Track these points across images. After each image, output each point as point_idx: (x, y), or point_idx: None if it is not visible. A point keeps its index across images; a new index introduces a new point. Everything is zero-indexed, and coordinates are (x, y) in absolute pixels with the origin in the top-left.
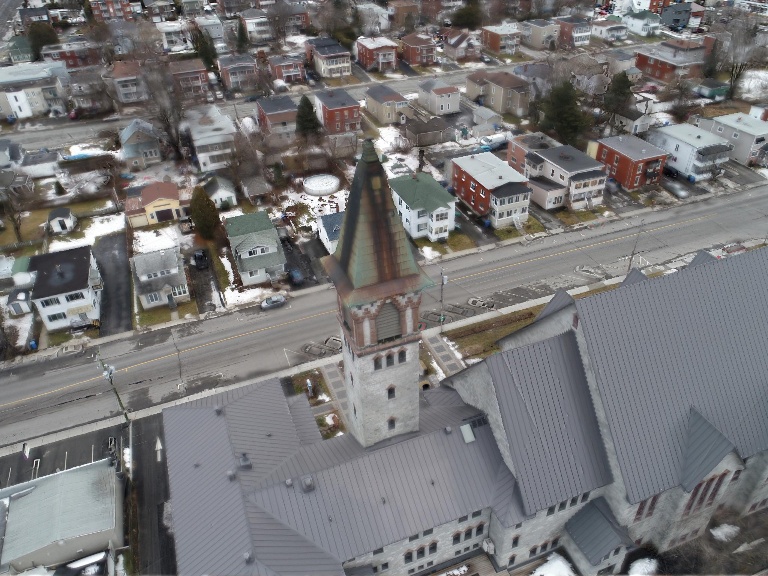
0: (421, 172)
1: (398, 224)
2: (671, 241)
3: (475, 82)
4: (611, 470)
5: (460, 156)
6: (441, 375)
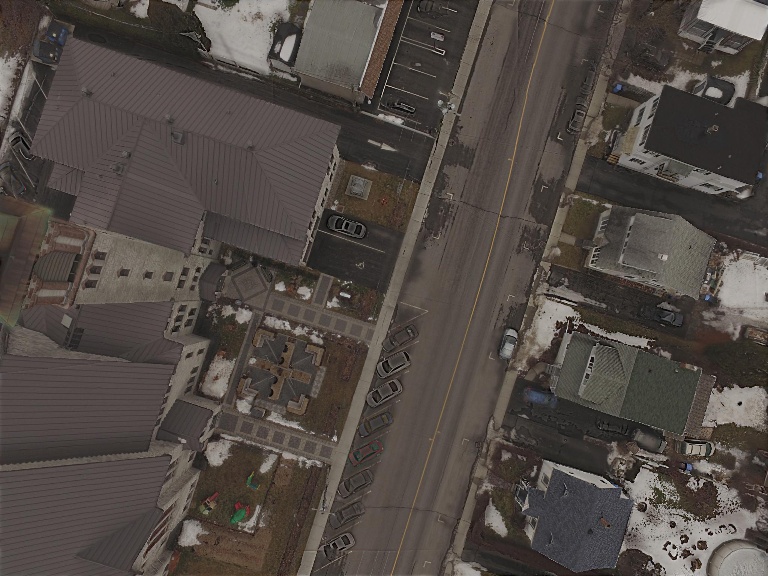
0: None
1: None
2: None
3: None
4: None
5: None
6: (278, 419)
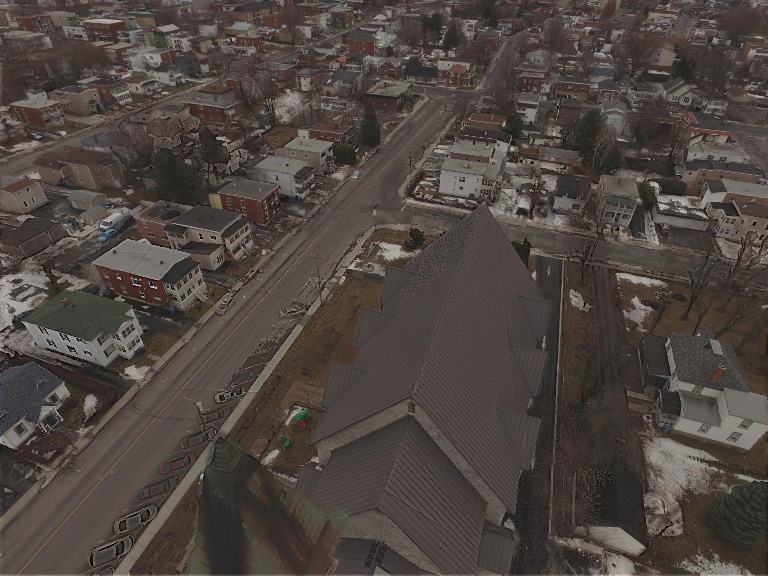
0: (64, 291)
1: (292, 498)
2: (324, 255)
3: (48, 166)
4: (483, 498)
5: (98, 255)
6: None
